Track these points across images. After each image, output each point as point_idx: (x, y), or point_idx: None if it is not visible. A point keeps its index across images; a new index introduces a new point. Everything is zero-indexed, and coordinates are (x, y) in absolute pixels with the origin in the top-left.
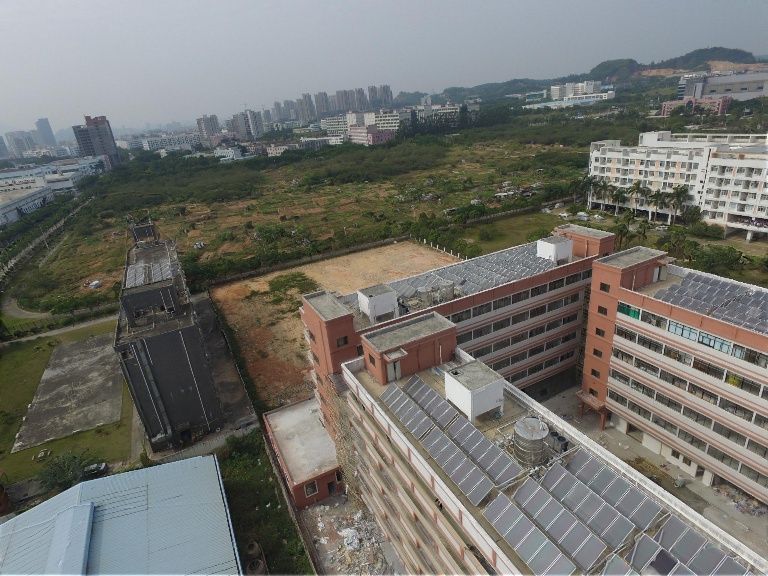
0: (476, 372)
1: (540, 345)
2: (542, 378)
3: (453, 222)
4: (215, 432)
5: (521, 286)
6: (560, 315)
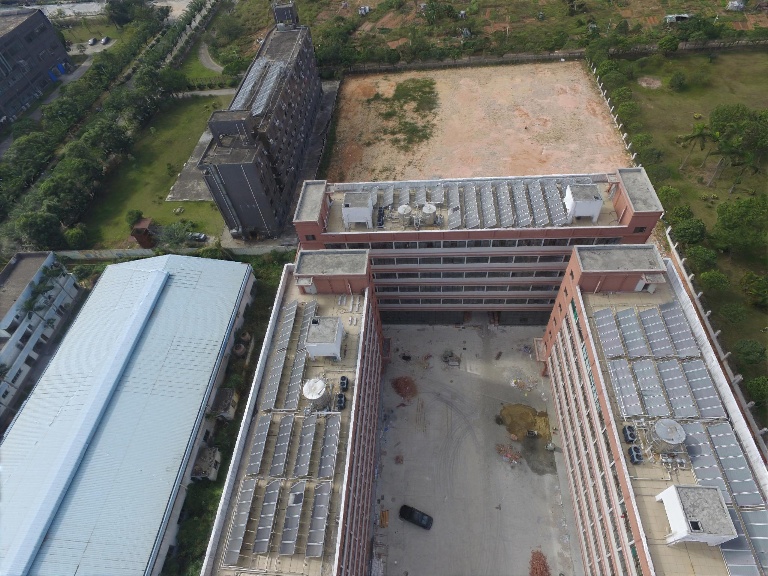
0: (327, 328)
1: (525, 285)
2: (524, 309)
3: (657, 45)
4: (273, 239)
5: (505, 235)
6: (556, 268)
